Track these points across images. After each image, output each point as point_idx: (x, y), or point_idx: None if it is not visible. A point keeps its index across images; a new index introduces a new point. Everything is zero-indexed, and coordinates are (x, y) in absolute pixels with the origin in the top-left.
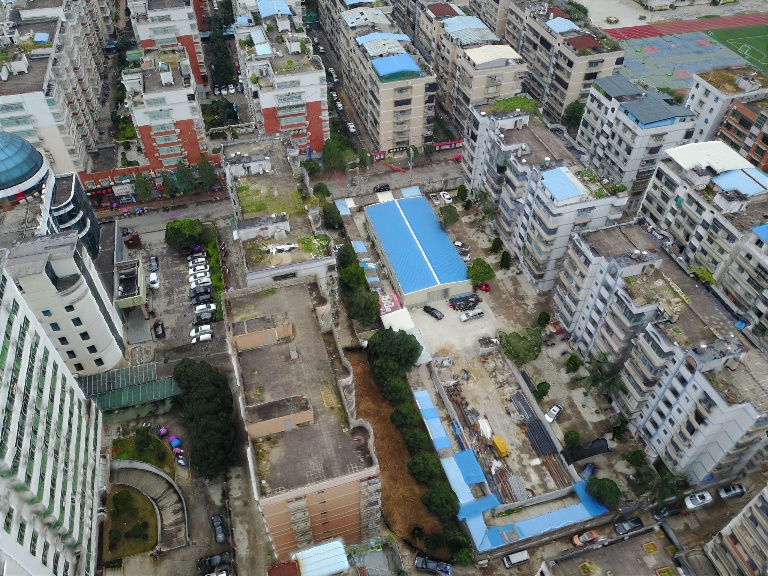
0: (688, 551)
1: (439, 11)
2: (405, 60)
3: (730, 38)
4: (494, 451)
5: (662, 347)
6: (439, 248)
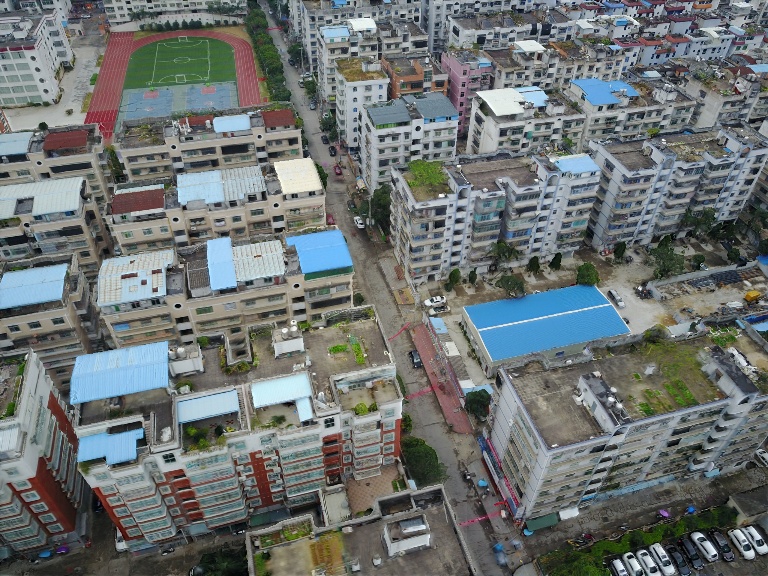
0: (767, 233)
1: (144, 203)
2: (312, 240)
3: (150, 80)
4: (752, 302)
5: (731, 161)
6: (554, 302)
